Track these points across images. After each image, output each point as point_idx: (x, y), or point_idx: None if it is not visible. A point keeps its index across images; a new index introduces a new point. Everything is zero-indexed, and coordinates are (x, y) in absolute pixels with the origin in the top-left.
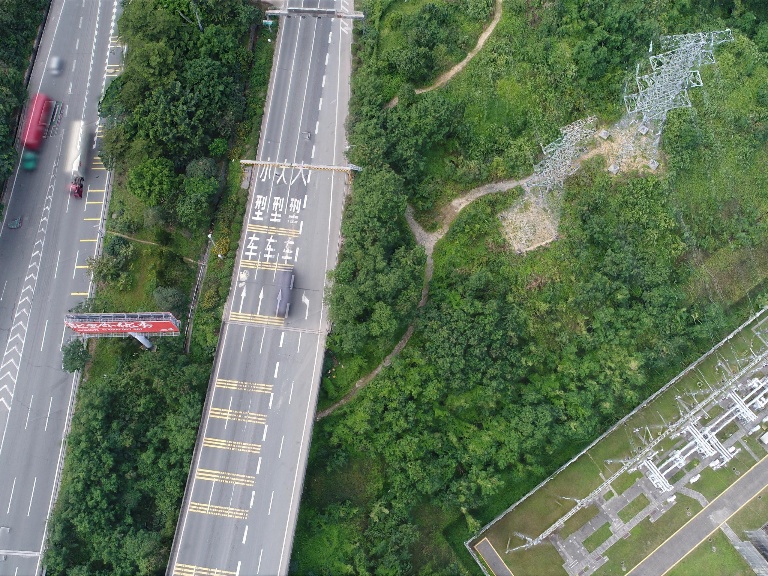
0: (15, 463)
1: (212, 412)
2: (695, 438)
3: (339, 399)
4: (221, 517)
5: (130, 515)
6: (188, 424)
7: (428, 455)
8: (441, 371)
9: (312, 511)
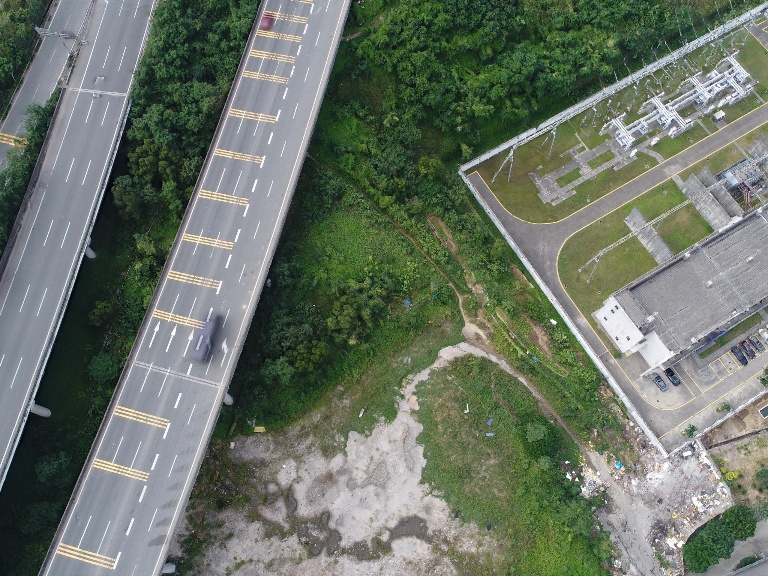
0: (110, 37)
1: (265, 14)
2: (657, 107)
3: (365, 26)
4: (267, 81)
5: (196, 80)
6: (246, 15)
7: (434, 78)
8: (449, 6)
9: (338, 106)
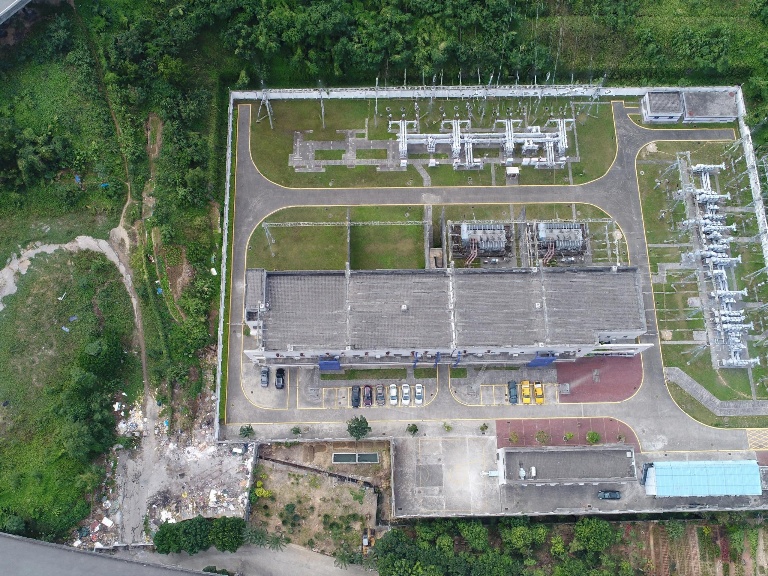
0: None
1: None
2: (453, 131)
3: None
4: None
5: None
6: None
7: None
8: None
9: None
